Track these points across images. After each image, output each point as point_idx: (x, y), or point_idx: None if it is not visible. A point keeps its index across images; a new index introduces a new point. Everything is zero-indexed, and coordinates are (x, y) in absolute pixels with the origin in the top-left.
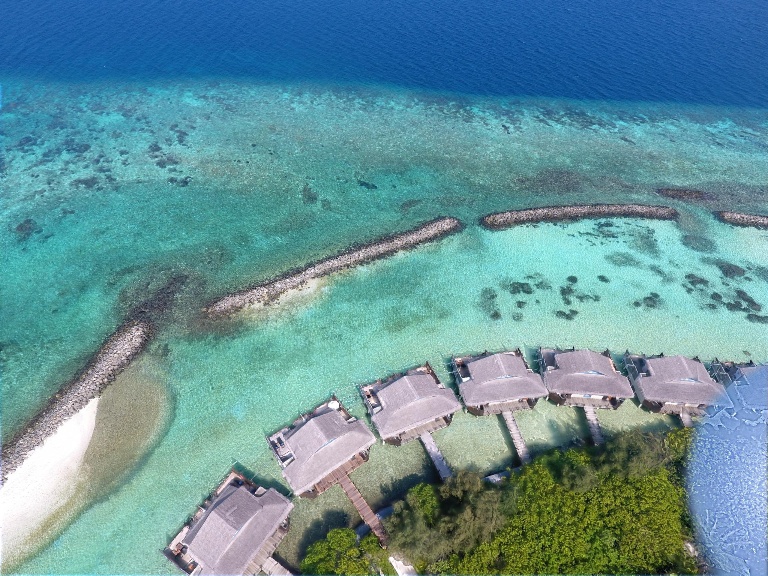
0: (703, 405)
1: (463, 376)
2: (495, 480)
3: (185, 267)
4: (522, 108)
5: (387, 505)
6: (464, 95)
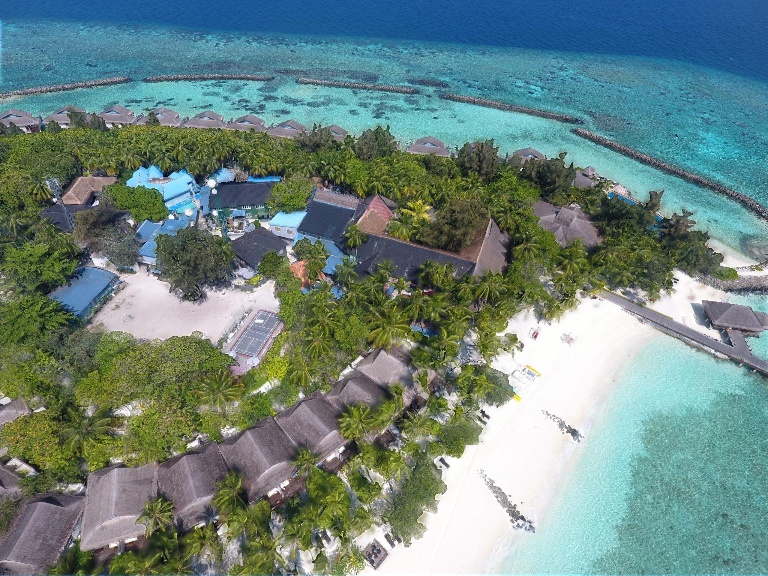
0: None
1: None
2: None
3: None
4: (243, 36)
5: None
6: None
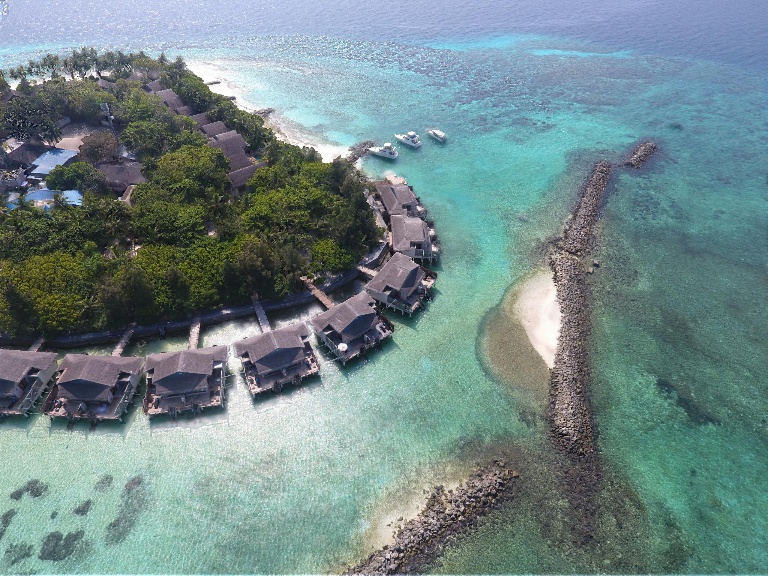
0: None
1: (218, 379)
2: (226, 310)
3: (594, 569)
4: None
5: (305, 305)
6: None
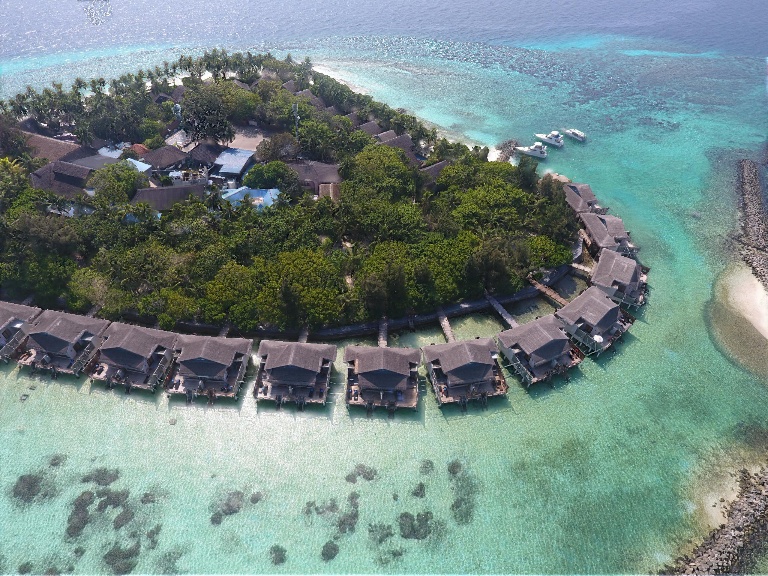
0: None
1: (494, 370)
2: (464, 304)
3: None
4: None
5: (531, 300)
6: None
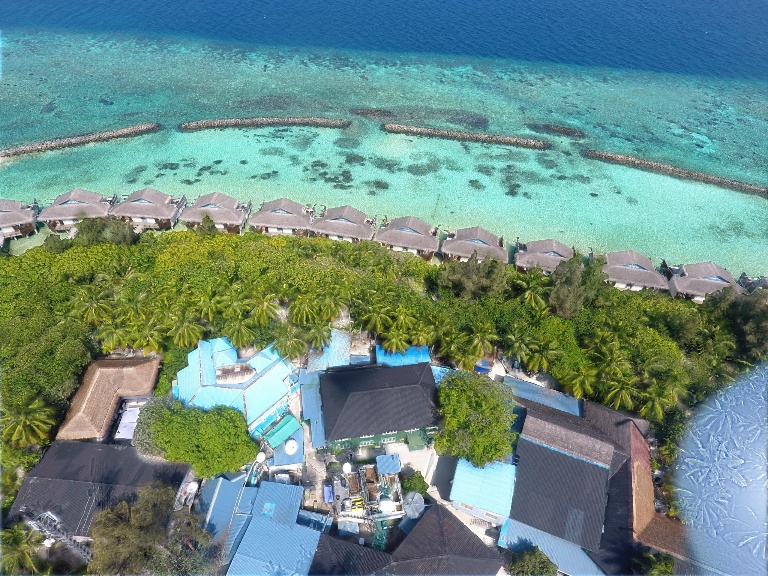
0: (226, 226)
1: None
2: None
3: None
4: (295, 54)
5: None
6: (251, 44)
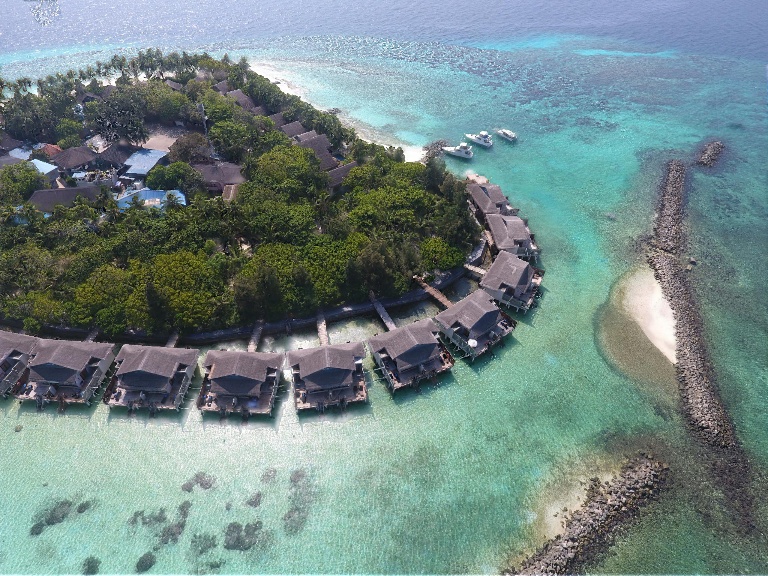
0: None
1: (359, 375)
2: (347, 308)
3: (763, 558)
4: None
5: (420, 303)
6: None
